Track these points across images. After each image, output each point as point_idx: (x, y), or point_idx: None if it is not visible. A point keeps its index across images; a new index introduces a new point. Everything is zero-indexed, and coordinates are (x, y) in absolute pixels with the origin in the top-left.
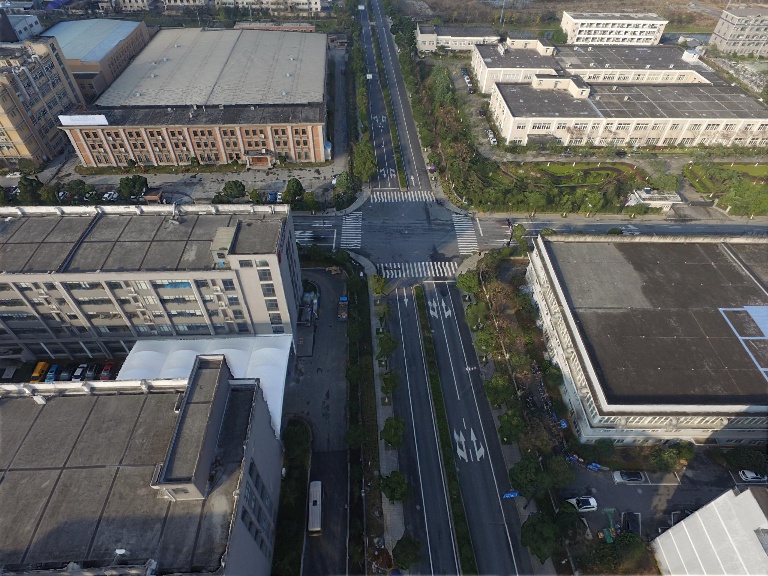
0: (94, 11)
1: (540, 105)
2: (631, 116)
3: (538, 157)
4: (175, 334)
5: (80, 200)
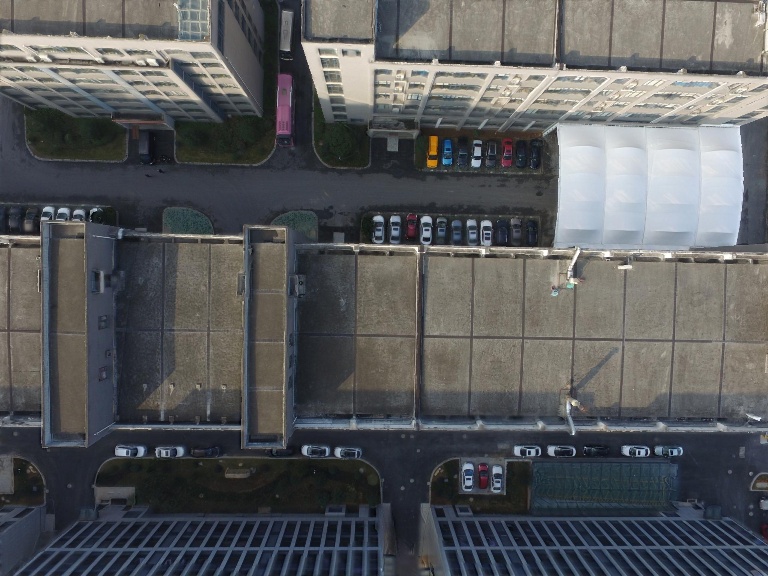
0: None
1: None
2: None
3: None
4: (610, 120)
5: None
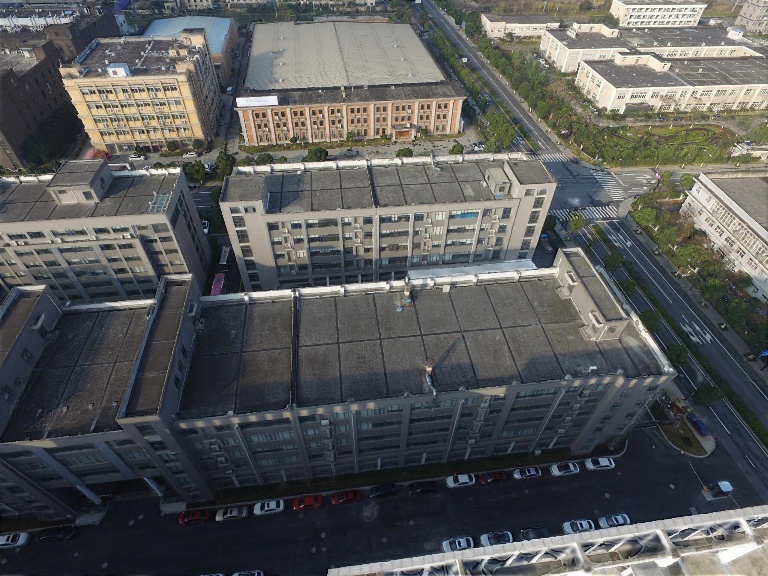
0: (160, 11)
1: (631, 78)
2: (712, 84)
3: (637, 123)
4: (441, 263)
5: None
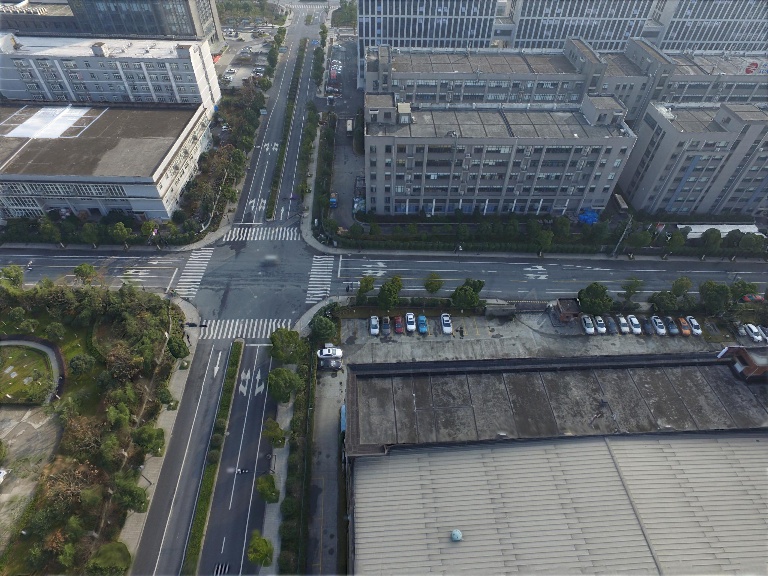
0: None
1: None
2: None
3: None
4: None
5: (661, 315)
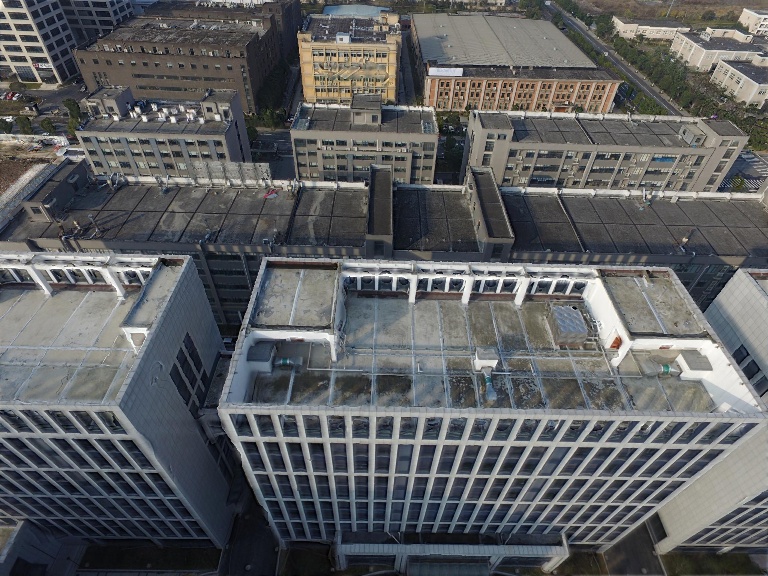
0: (315, 1)
1: None
2: None
3: None
4: None
5: None
